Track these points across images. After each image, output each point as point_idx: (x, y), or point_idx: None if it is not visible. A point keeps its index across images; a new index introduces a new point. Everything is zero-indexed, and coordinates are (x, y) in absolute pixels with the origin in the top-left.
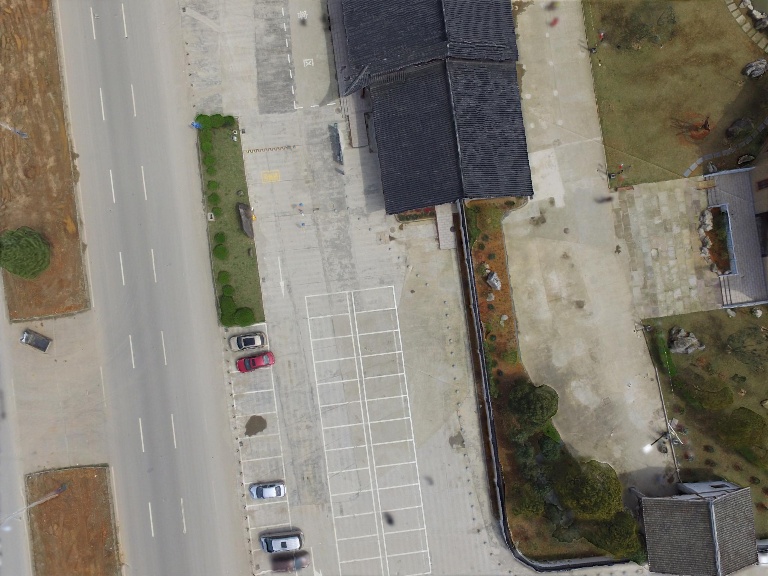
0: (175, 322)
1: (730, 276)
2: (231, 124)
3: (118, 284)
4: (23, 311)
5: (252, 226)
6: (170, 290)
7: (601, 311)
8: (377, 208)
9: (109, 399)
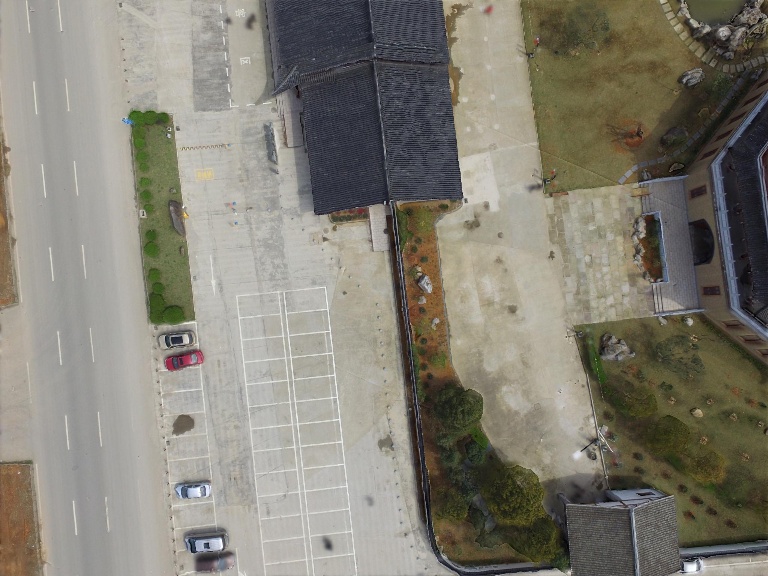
0: (104, 319)
1: (662, 284)
2: (165, 121)
3: (47, 280)
4: None
5: (183, 224)
6: (100, 287)
7: (533, 316)
8: (311, 208)
9: (35, 395)
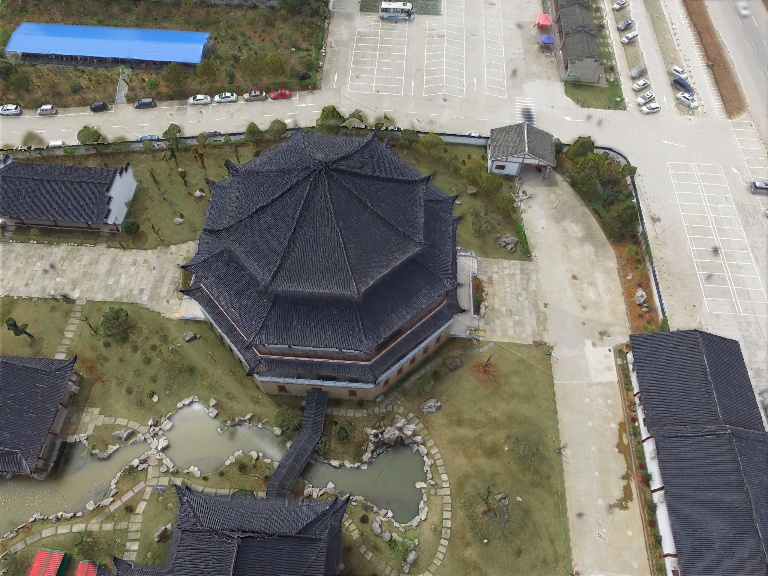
0: None
1: None
2: None
3: None
4: None
5: None
6: None
7: (560, 271)
8: None
9: None
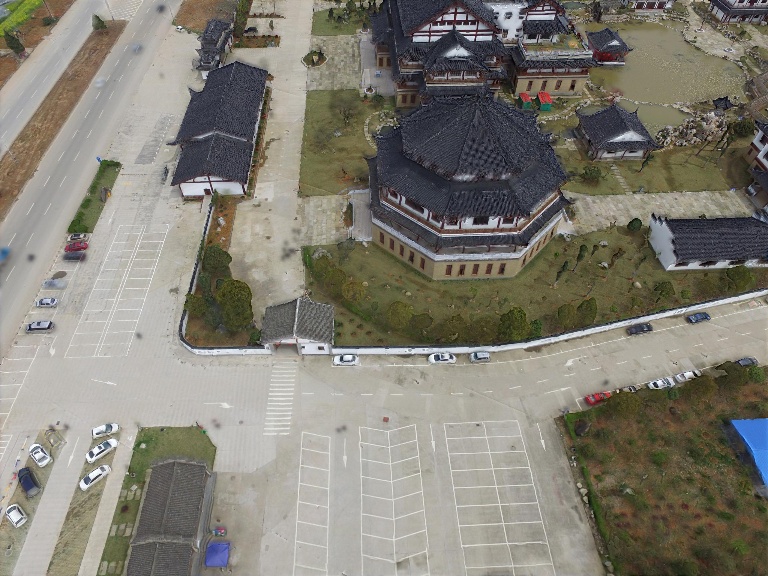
0: (44, 230)
1: (352, 229)
2: (118, 165)
3: (24, 214)
4: None
5: (106, 197)
6: (50, 218)
7: (279, 241)
8: (175, 197)
9: None
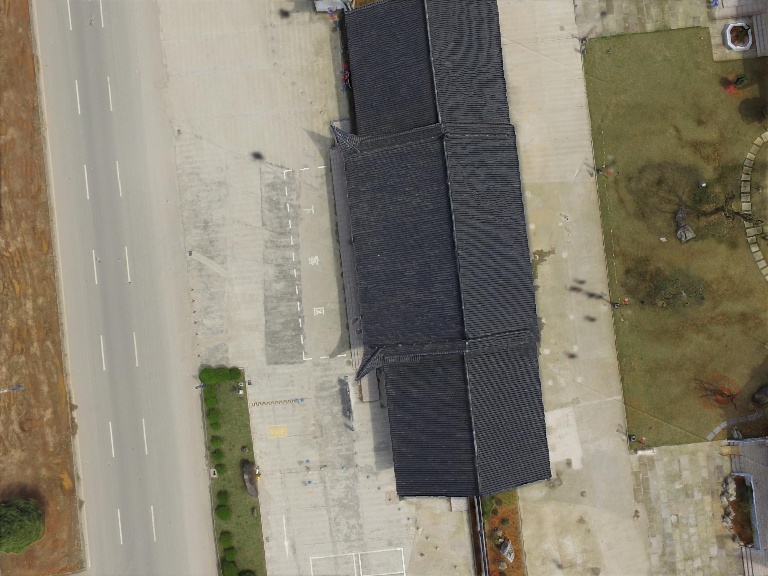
0: None
1: (752, 548)
2: (237, 377)
3: (116, 543)
4: (16, 572)
5: (256, 487)
6: (170, 549)
7: None
8: (387, 466)
9: None
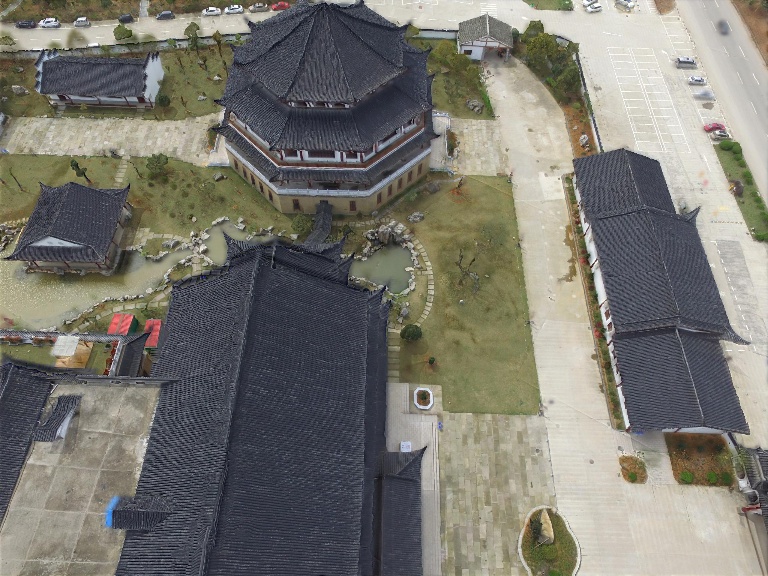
0: (766, 150)
1: None
2: None
3: None
4: None
5: None
6: None
7: (518, 126)
8: None
9: None
